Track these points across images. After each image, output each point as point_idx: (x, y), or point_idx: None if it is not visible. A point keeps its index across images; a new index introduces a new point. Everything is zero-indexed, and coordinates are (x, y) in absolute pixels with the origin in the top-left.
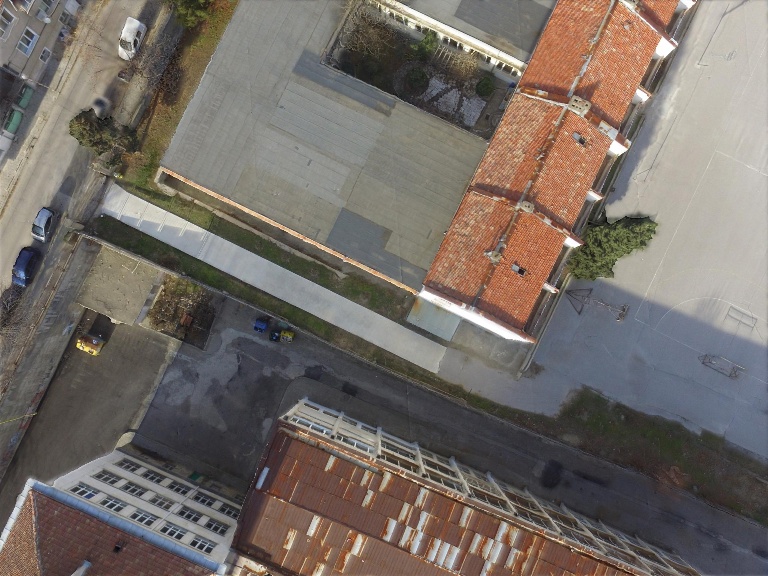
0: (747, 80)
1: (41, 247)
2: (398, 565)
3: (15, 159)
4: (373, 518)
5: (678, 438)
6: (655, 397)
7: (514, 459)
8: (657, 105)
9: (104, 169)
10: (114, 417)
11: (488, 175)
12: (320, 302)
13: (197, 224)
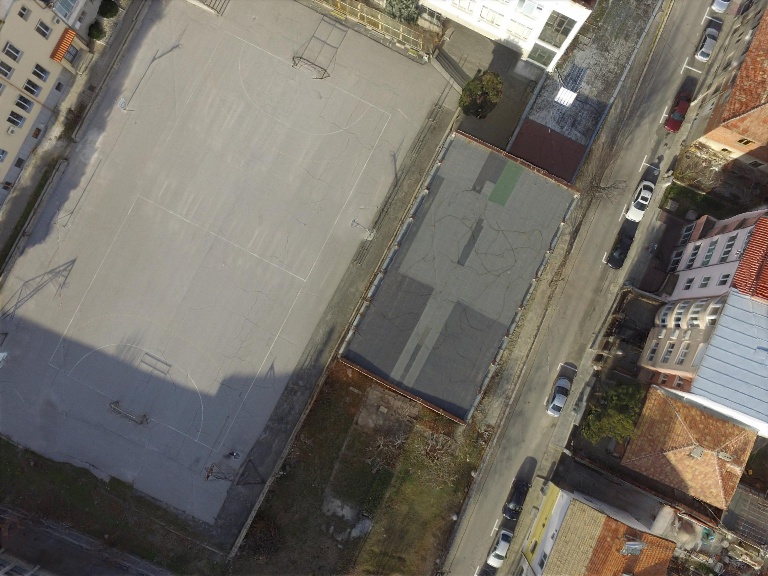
0: (173, 126)
1: None
2: None
3: None
4: None
5: (86, 486)
6: (65, 444)
7: None
8: (82, 149)
9: None
10: None
11: None
12: None
13: None
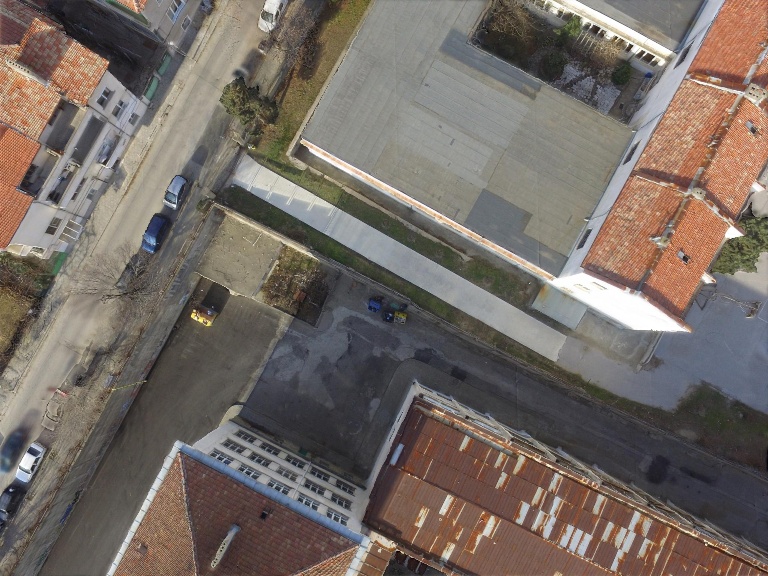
0: None
1: (170, 214)
2: (530, 549)
3: (149, 125)
4: (506, 501)
5: None
6: None
7: (621, 453)
8: None
9: (241, 139)
10: (223, 389)
11: (653, 160)
12: (443, 284)
13: (325, 199)
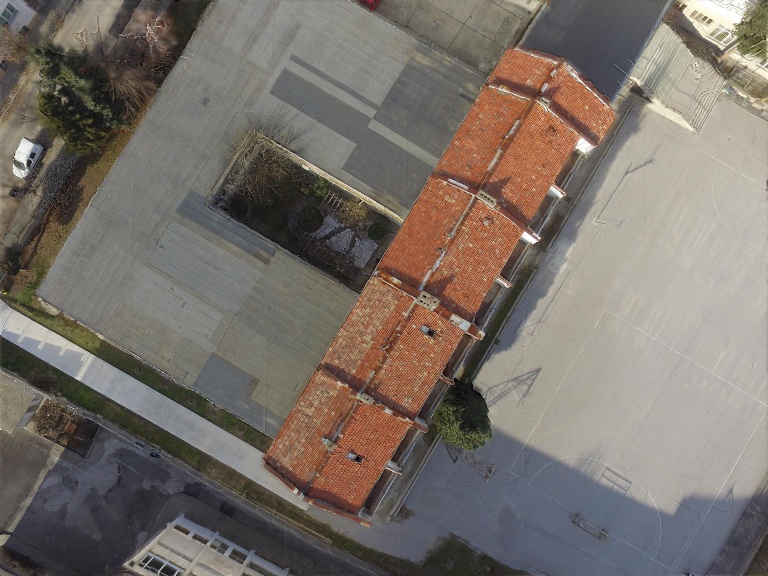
0: (643, 242)
1: None
2: None
3: None
4: None
5: None
6: (523, 552)
7: None
8: (551, 259)
9: None
10: None
11: (337, 356)
12: (195, 430)
13: (78, 344)
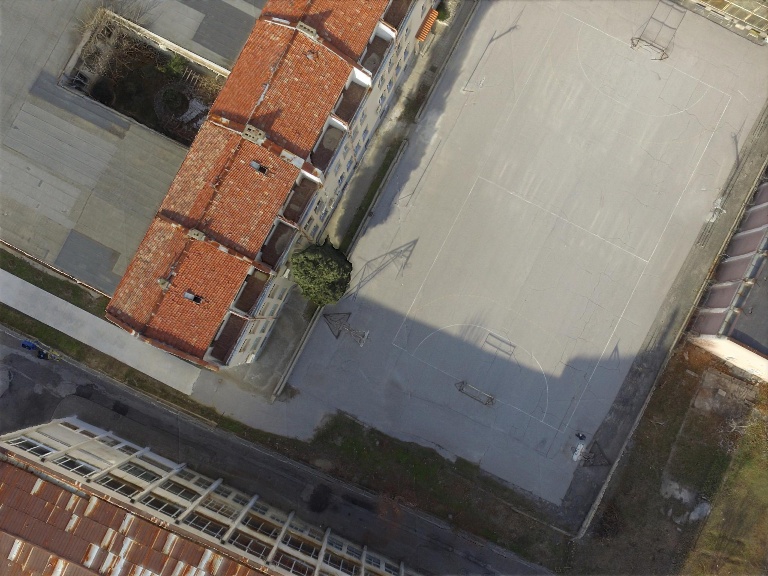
0: (512, 107)
1: None
2: None
3: None
4: (75, 543)
5: (432, 466)
6: (410, 424)
7: (283, 482)
8: (421, 130)
9: None
10: None
11: (173, 202)
12: (73, 321)
13: None
